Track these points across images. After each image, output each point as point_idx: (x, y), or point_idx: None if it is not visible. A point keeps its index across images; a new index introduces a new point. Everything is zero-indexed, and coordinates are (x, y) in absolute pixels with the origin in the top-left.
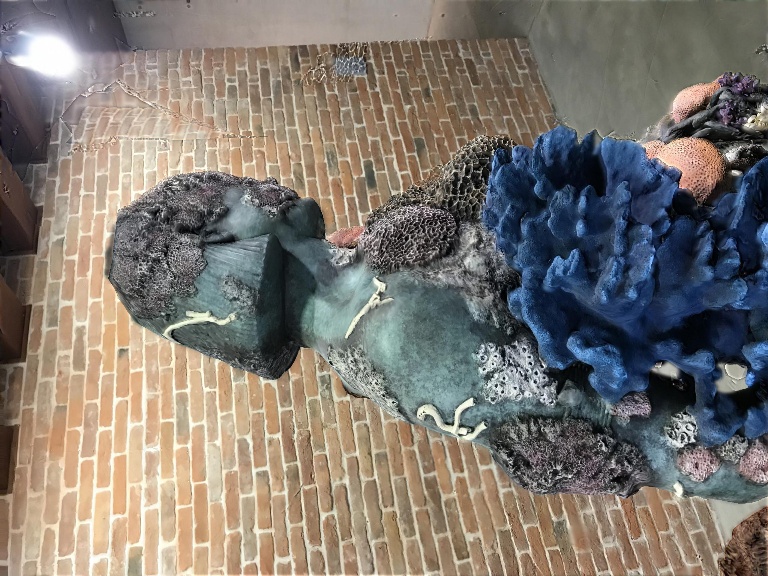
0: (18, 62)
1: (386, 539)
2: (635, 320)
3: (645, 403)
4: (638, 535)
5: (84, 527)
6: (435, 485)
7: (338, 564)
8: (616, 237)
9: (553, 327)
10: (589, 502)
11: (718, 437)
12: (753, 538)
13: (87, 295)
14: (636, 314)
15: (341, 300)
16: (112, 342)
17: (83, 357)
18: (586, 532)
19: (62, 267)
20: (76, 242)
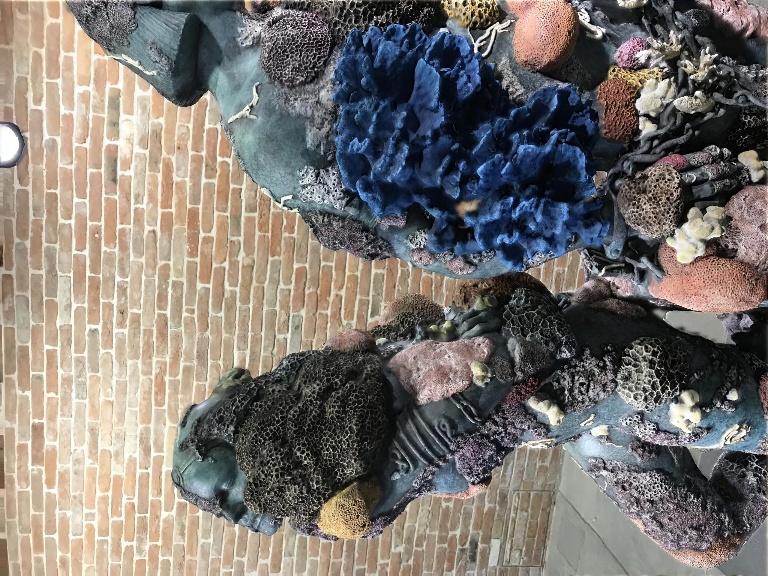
0: None
1: None
2: None
3: (403, 219)
4: None
5: (68, 59)
6: None
7: None
8: (390, 143)
9: (351, 170)
10: None
11: (435, 250)
12: (474, 283)
13: None
14: None
15: (236, 81)
16: None
17: None
18: None
19: None
20: None
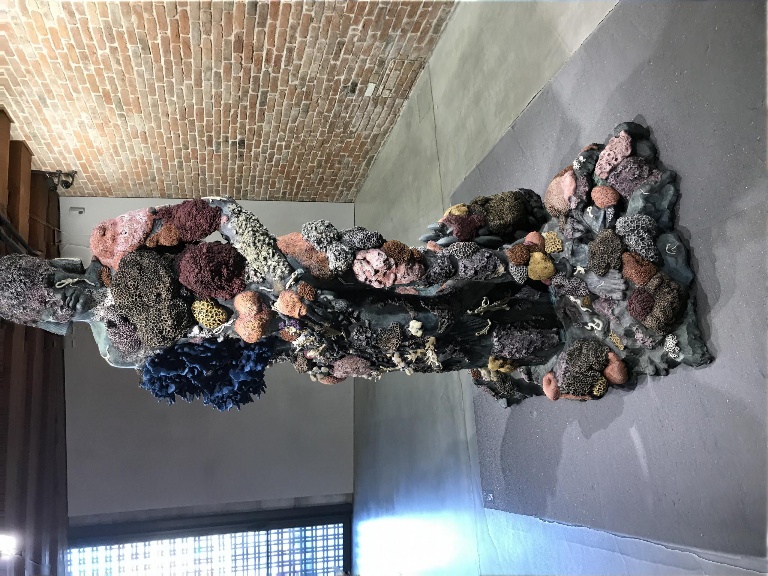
0: None
1: None
2: None
3: None
4: None
5: None
6: None
7: None
8: None
9: None
10: None
11: None
12: None
13: None
14: None
15: None
16: None
17: None
18: None
19: None
20: None
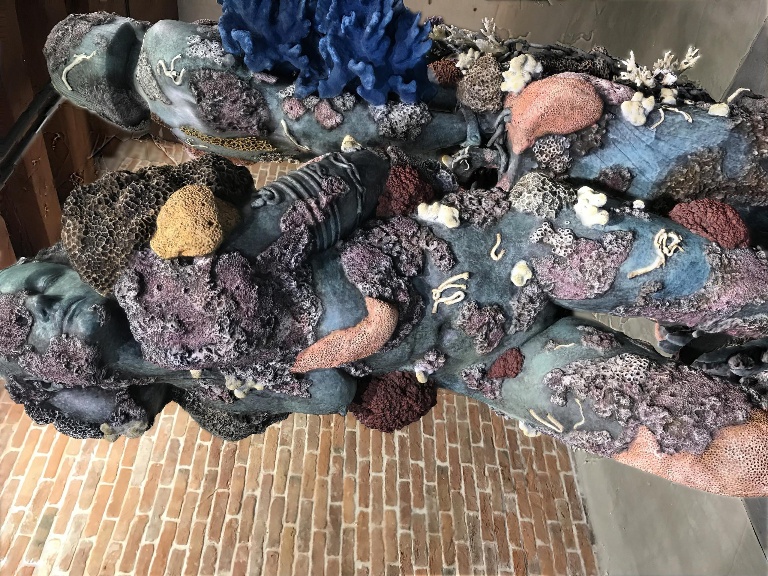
0: None
1: (280, 550)
2: (267, 28)
3: (274, 79)
4: None
5: (14, 481)
6: (339, 514)
7: (229, 563)
8: None
9: (229, 29)
10: (483, 559)
11: (301, 90)
12: None
13: None
14: (263, 19)
15: None
16: None
17: None
18: None
19: None
20: None
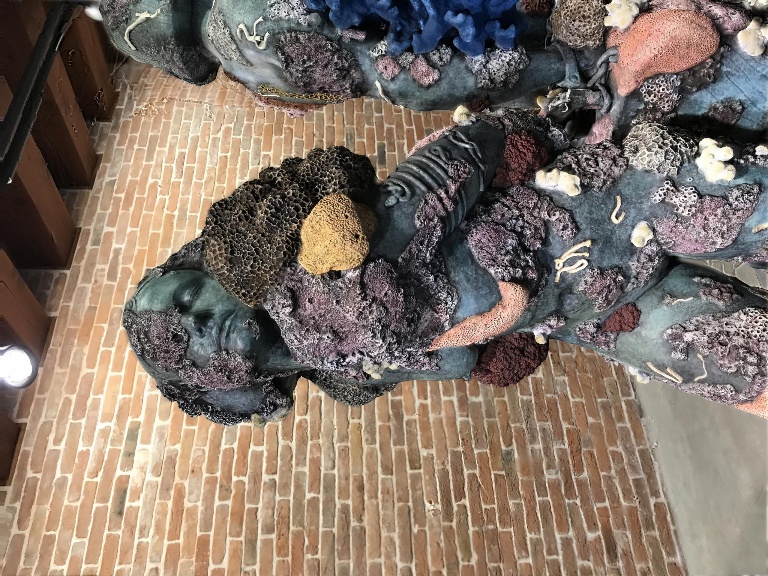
0: (94, 16)
1: (349, 444)
2: None
3: (362, 35)
4: (581, 473)
5: (96, 400)
6: (400, 407)
7: (304, 459)
8: None
9: None
10: (538, 438)
11: (395, 48)
12: None
13: (127, 225)
14: None
15: None
16: (142, 262)
17: (116, 271)
18: (532, 463)
19: (110, 201)
20: (125, 184)
